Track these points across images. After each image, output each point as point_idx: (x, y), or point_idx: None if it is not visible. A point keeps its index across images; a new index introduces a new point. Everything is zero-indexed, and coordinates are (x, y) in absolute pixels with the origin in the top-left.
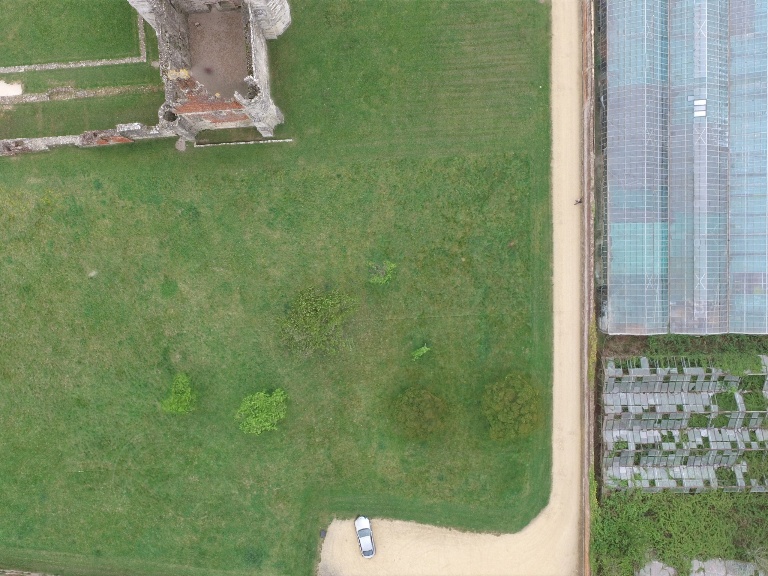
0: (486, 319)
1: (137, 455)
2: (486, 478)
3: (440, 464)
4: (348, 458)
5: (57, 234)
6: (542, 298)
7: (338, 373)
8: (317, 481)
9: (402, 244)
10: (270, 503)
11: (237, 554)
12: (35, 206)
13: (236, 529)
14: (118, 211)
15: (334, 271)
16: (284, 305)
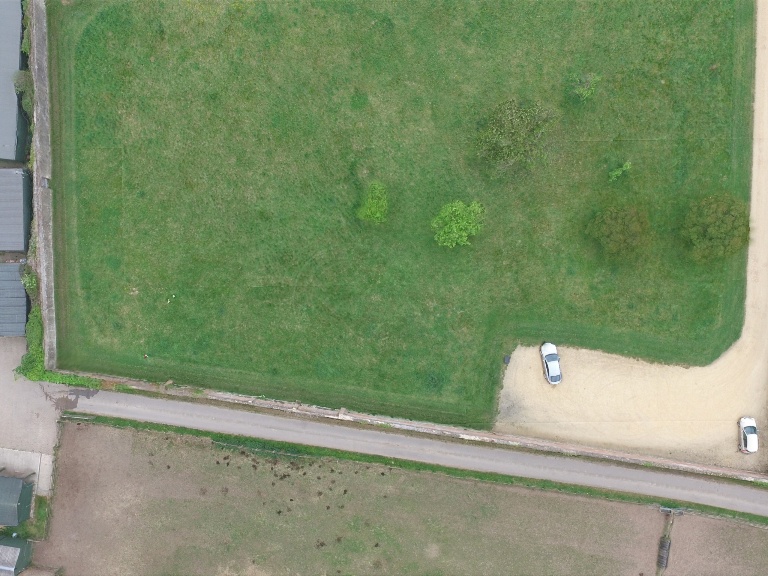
0: (684, 144)
1: (319, 271)
2: (677, 308)
3: (630, 292)
4: (535, 283)
5: (247, 41)
6: (742, 124)
7: (529, 195)
8: (503, 305)
9: (600, 64)
10: (453, 326)
11: (417, 378)
12: (226, 11)
13: (417, 352)
14: (310, 20)
15: (529, 89)
16: (476, 122)
